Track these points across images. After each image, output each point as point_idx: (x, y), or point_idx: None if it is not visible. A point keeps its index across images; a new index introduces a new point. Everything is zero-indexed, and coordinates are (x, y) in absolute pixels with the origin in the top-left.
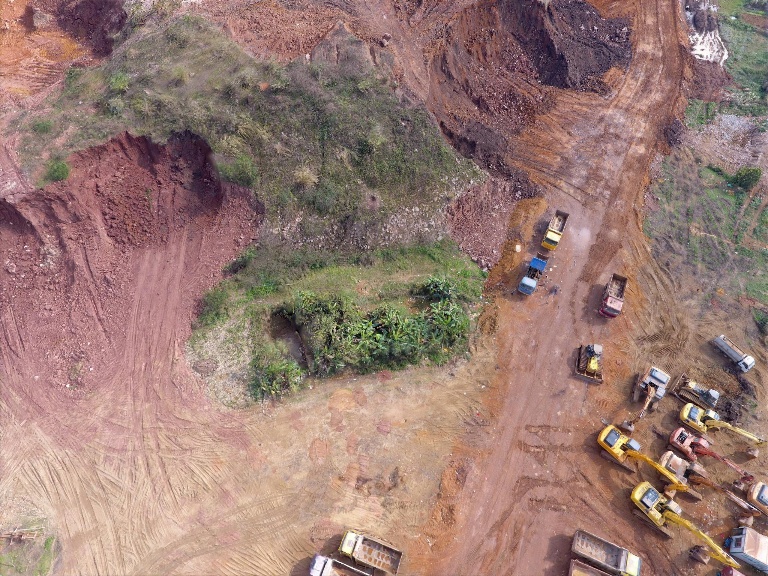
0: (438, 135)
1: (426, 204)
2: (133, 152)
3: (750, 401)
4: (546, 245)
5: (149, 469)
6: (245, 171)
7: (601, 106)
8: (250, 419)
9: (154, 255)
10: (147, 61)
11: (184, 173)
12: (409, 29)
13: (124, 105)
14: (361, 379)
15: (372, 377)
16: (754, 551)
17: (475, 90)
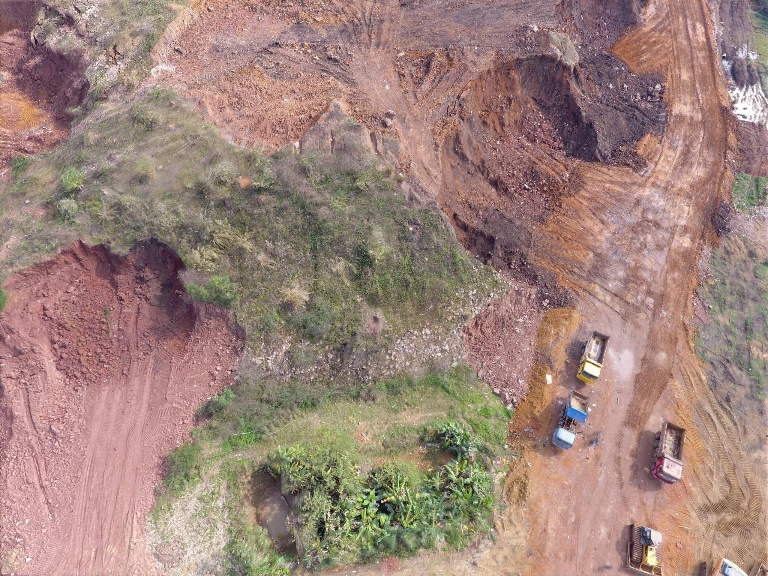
0: (452, 240)
1: (438, 325)
2: (90, 261)
3: None
4: (583, 378)
5: None
6: (221, 291)
7: (636, 185)
8: None
9: (112, 393)
10: (107, 149)
11: (150, 286)
12: (416, 103)
13: (78, 207)
14: (362, 571)
15: (375, 568)
16: None
17: (492, 170)
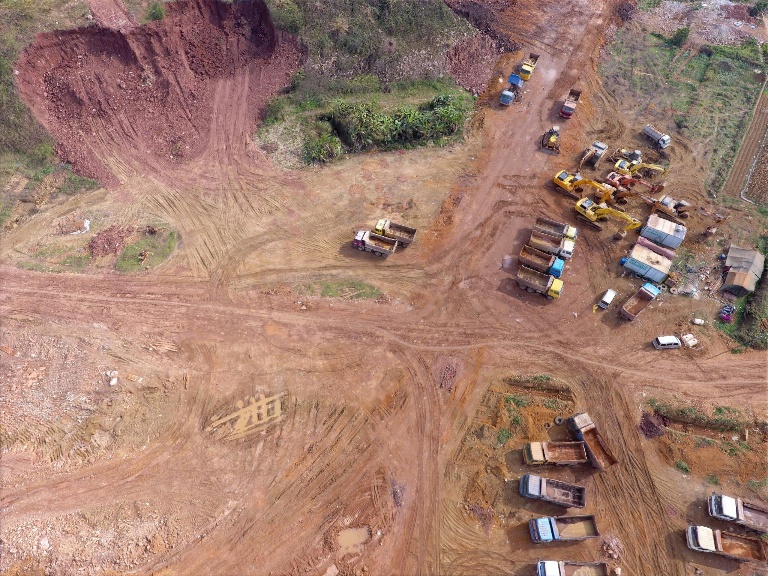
0: None
1: (431, 48)
2: (206, 11)
3: (665, 162)
4: (522, 76)
5: (236, 199)
6: (294, 20)
7: None
8: (305, 175)
9: (225, 82)
10: None
11: (245, 28)
12: None
13: None
14: (384, 154)
15: (392, 153)
16: (654, 225)
17: None
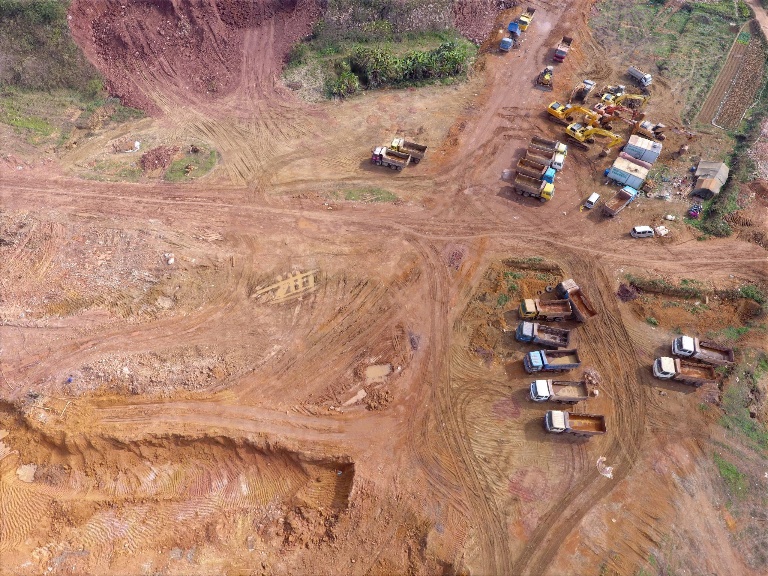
0: None
1: (438, 3)
2: None
3: None
4: (520, 27)
5: (267, 126)
6: None
7: None
8: (327, 107)
9: (253, 32)
10: None
11: None
12: None
13: None
14: (397, 91)
15: (404, 90)
16: (634, 143)
17: None
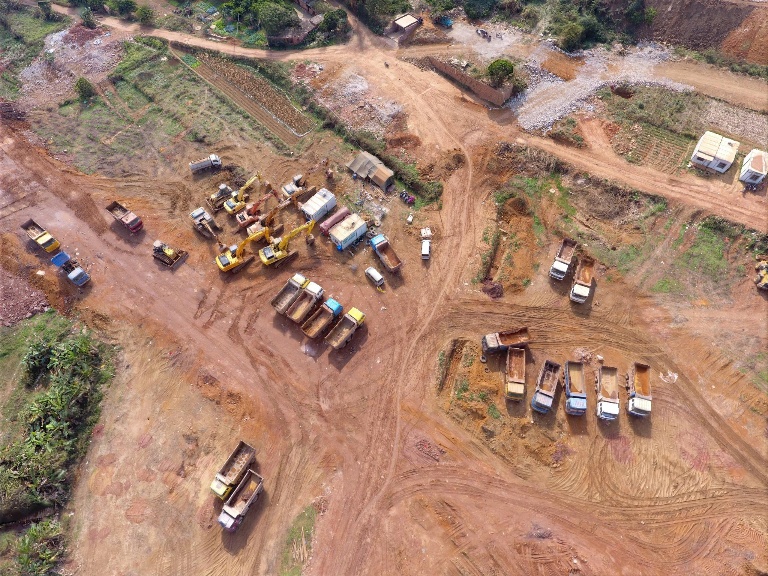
0: None
1: None
2: None
3: (239, 170)
4: (51, 249)
5: None
6: None
7: None
8: None
9: None
10: None
11: None
12: None
13: None
14: (90, 456)
15: (93, 444)
16: (313, 210)
17: None
